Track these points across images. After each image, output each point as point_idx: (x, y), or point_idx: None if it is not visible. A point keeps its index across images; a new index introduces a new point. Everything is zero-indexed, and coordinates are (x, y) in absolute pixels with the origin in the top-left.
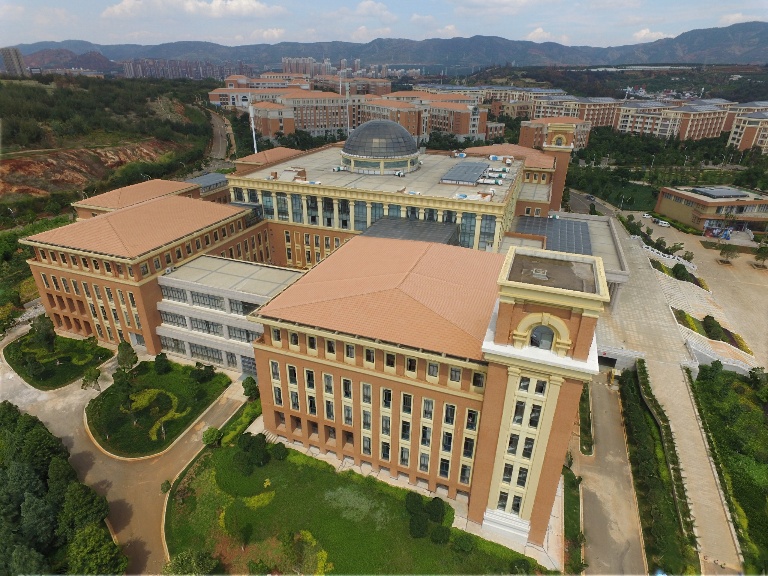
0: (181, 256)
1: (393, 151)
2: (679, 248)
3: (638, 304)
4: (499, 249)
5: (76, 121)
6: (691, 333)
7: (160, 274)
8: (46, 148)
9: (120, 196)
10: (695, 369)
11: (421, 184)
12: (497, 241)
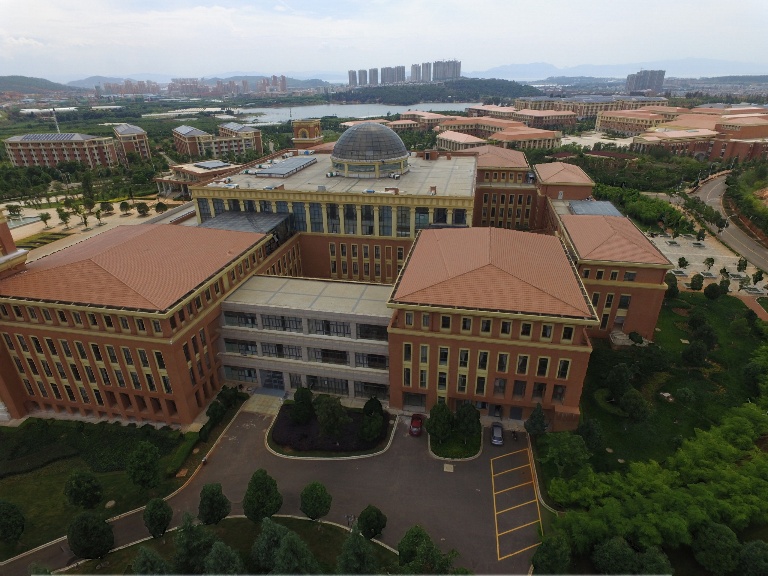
0: None
1: None
2: None
3: None
4: None
5: None
6: None
7: None
8: None
9: None
10: None
11: None
12: None
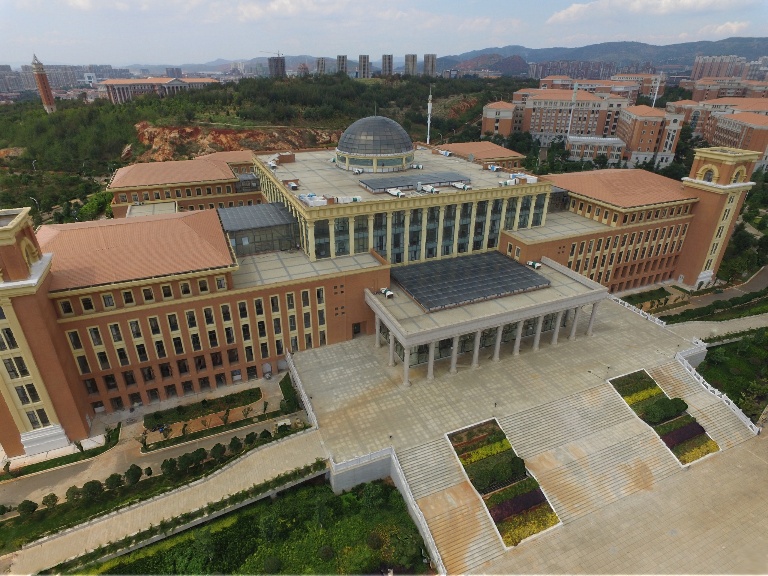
0: (160, 198)
1: (357, 148)
2: (767, 390)
3: (463, 395)
4: (328, 260)
5: (323, 108)
6: (448, 455)
7: (131, 204)
8: (285, 125)
9: (210, 157)
10: (332, 471)
11: (344, 182)
12: (310, 248)
